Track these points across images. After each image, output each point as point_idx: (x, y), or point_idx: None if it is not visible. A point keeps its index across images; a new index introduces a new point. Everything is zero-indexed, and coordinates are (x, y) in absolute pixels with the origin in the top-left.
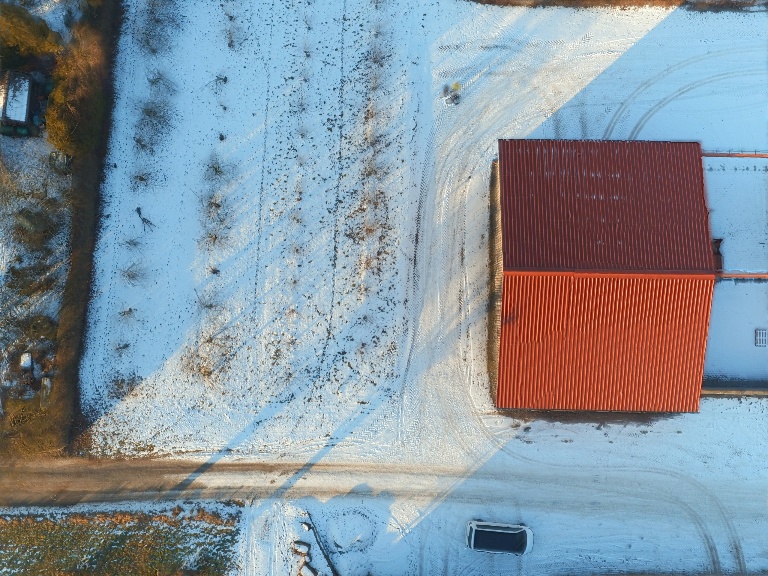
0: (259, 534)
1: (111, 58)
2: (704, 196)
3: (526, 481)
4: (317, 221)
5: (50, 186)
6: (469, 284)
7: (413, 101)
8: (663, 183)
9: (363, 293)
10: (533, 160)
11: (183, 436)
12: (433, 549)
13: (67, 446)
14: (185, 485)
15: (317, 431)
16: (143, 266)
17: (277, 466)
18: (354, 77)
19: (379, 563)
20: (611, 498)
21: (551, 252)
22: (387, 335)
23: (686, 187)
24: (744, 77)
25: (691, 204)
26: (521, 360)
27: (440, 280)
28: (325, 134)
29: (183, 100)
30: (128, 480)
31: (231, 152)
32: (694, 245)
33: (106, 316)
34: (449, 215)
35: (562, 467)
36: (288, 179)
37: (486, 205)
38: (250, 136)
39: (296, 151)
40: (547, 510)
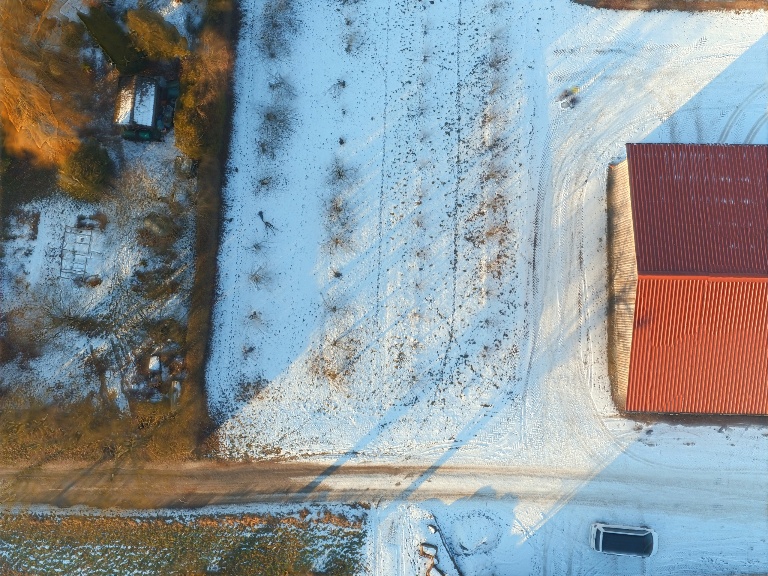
0: (386, 536)
1: (230, 63)
2: None
3: (648, 484)
4: (437, 225)
5: (173, 190)
6: (588, 287)
7: (529, 105)
8: None
9: (484, 296)
10: (662, 164)
11: (309, 439)
12: (557, 551)
13: (195, 449)
14: (311, 487)
15: (441, 434)
16: (267, 270)
17: (402, 469)
18: (471, 81)
19: (503, 565)
20: (733, 501)
21: (684, 256)
22: (508, 338)
23: None
24: None
25: None
26: (652, 363)
27: (559, 283)
28: (443, 138)
29: (302, 104)
30: (255, 482)
31: (351, 156)
32: None
33: (231, 319)
34: (567, 219)
35: (684, 470)
36: (408, 183)
37: (603, 209)
38: (369, 140)
39: (415, 155)
40: (669, 513)
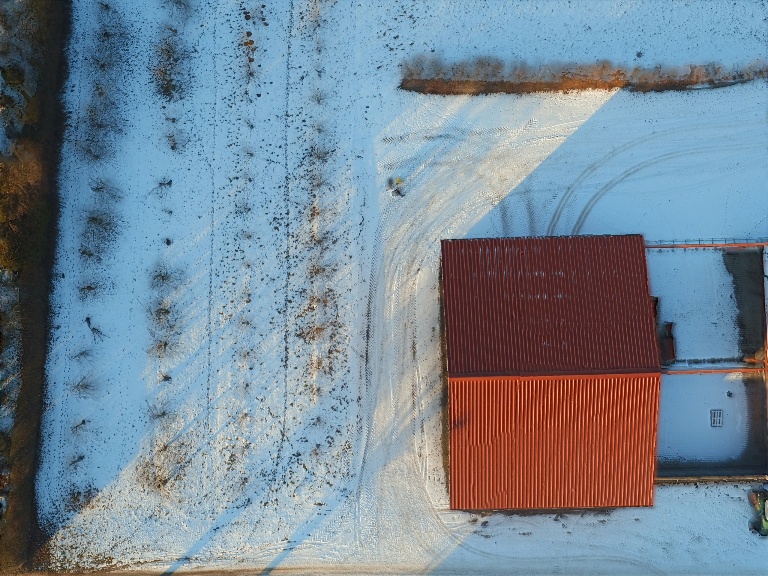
0: None
1: (55, 167)
2: (654, 278)
3: (485, 575)
4: (267, 322)
5: None
6: (422, 378)
7: (359, 195)
8: (607, 279)
9: (315, 393)
10: (476, 260)
11: (141, 547)
12: None
13: (26, 562)
14: None
15: (274, 535)
16: (94, 377)
17: (236, 572)
18: (299, 174)
19: None
20: None
21: (496, 356)
22: (341, 434)
23: (630, 282)
24: (690, 156)
25: (635, 299)
26: (472, 462)
27: (392, 375)
28: (272, 233)
29: (129, 206)
30: None
31: (178, 257)
32: (639, 342)
33: (60, 429)
34: (399, 309)
35: (521, 559)
36: (236, 281)
37: (436, 297)
38: (197, 239)
39: (243, 252)
40: None
